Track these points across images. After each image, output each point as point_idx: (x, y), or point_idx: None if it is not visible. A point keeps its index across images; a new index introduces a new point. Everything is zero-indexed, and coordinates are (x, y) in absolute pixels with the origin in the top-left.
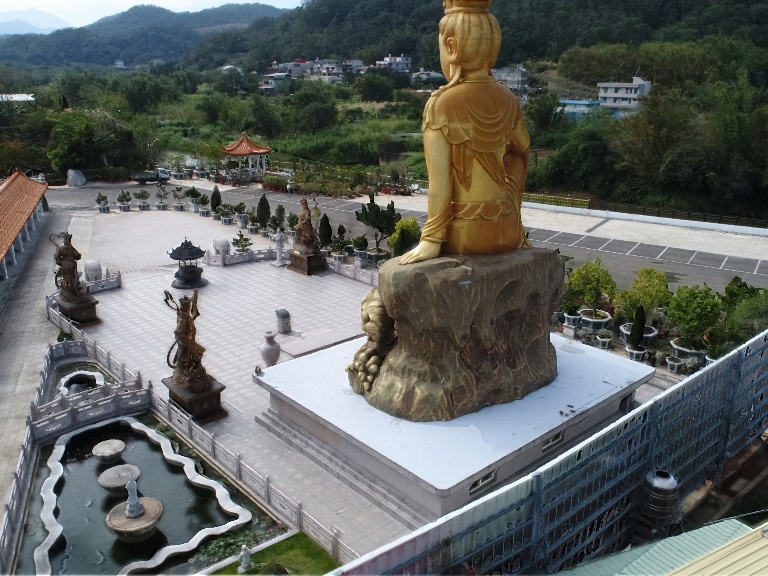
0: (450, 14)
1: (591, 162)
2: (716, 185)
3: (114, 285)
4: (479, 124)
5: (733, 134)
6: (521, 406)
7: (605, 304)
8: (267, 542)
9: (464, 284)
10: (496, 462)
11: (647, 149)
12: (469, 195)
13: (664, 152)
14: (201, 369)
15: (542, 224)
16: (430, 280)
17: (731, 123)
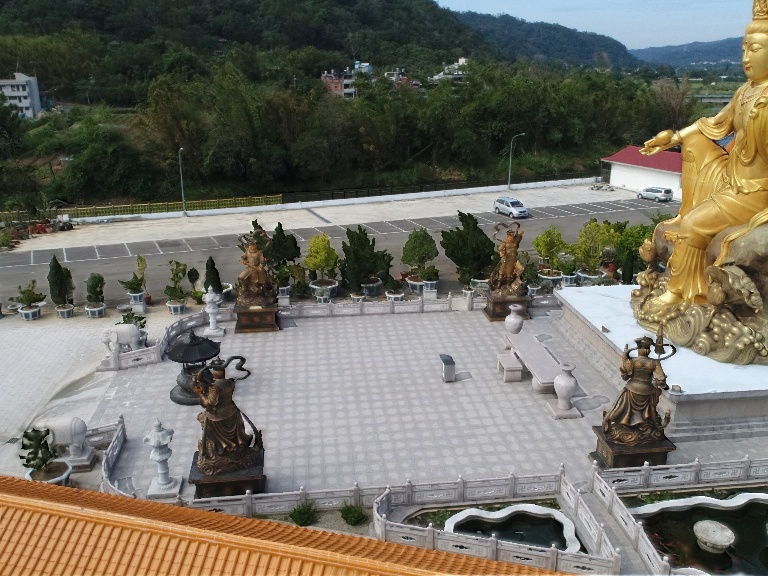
0: None
1: (126, 164)
2: (254, 170)
3: (120, 441)
4: None
5: (259, 122)
6: None
7: None
8: None
9: None
10: None
11: (184, 144)
12: None
13: (199, 145)
14: None
15: None
16: None
17: (254, 112)
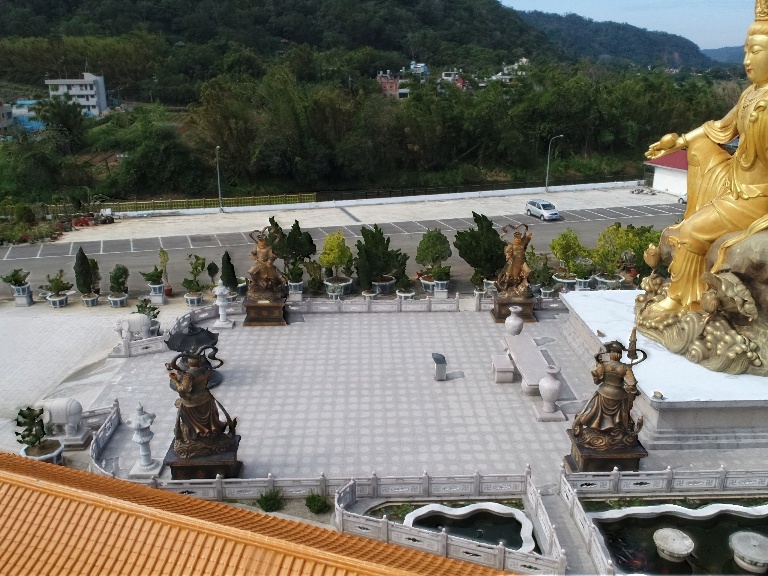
0: None
1: (177, 162)
2: (300, 168)
3: (115, 423)
4: None
5: (305, 122)
6: None
7: None
8: None
9: None
10: None
11: (232, 142)
12: None
13: (246, 144)
14: (631, 418)
15: (311, 223)
16: None
17: (301, 112)
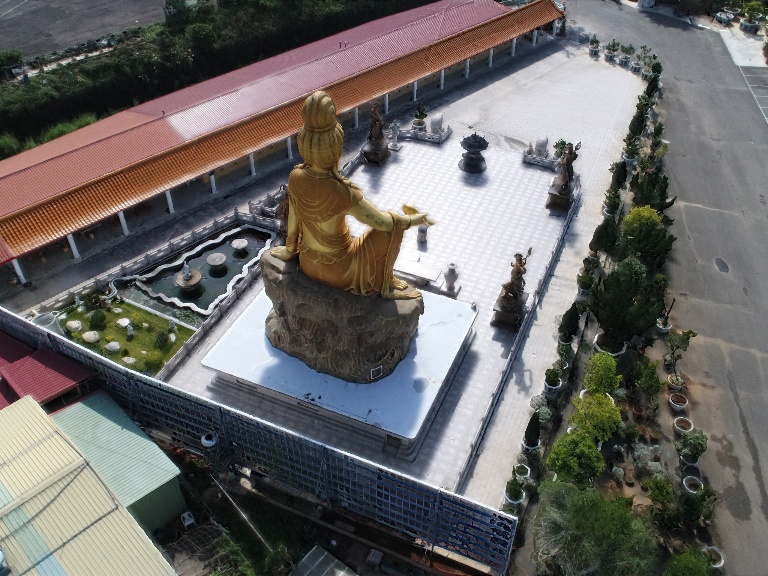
0: None
1: None
2: None
3: (436, 140)
4: (301, 201)
5: None
6: (309, 374)
7: (675, 411)
8: None
9: None
10: (237, 377)
11: None
12: None
13: None
14: (286, 235)
15: None
16: None
17: None
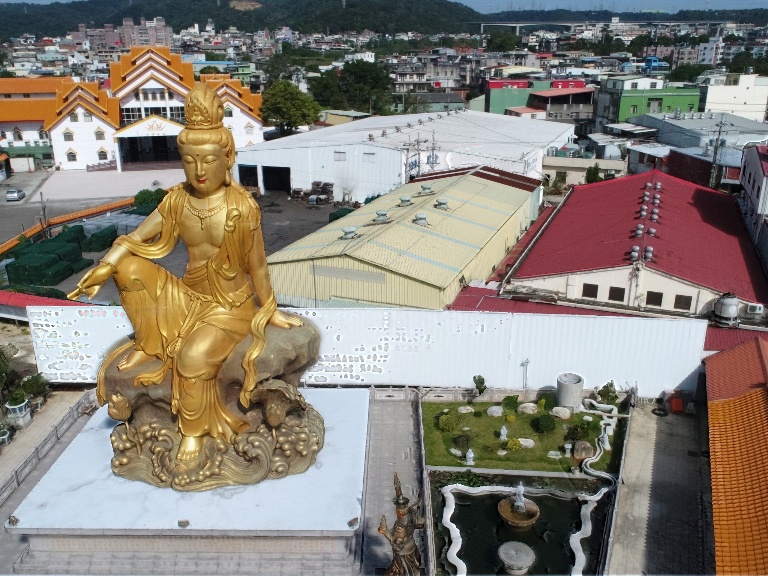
0: None
1: None
2: None
3: None
4: None
5: None
6: None
7: None
8: (448, 469)
9: None
10: None
11: None
12: None
13: None
14: None
15: None
16: None
17: None
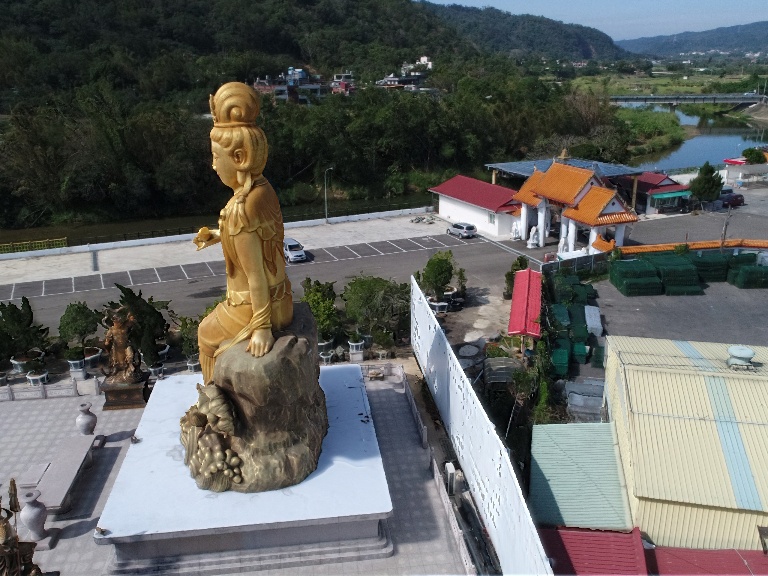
0: (230, 128)
1: None
2: (118, 194)
3: None
4: None
5: (119, 146)
6: (337, 431)
7: None
8: None
9: (310, 353)
10: None
11: (40, 170)
12: (276, 279)
13: (57, 171)
14: (36, 568)
15: (41, 275)
16: (292, 360)
17: (114, 136)
